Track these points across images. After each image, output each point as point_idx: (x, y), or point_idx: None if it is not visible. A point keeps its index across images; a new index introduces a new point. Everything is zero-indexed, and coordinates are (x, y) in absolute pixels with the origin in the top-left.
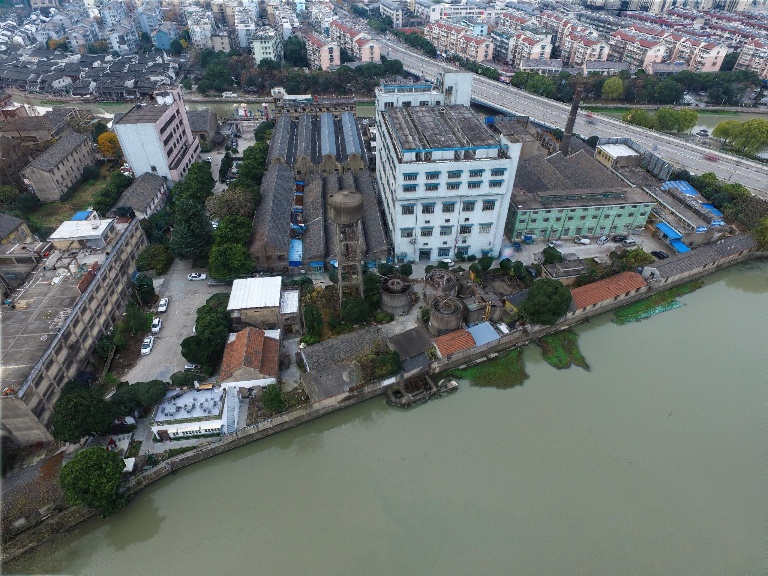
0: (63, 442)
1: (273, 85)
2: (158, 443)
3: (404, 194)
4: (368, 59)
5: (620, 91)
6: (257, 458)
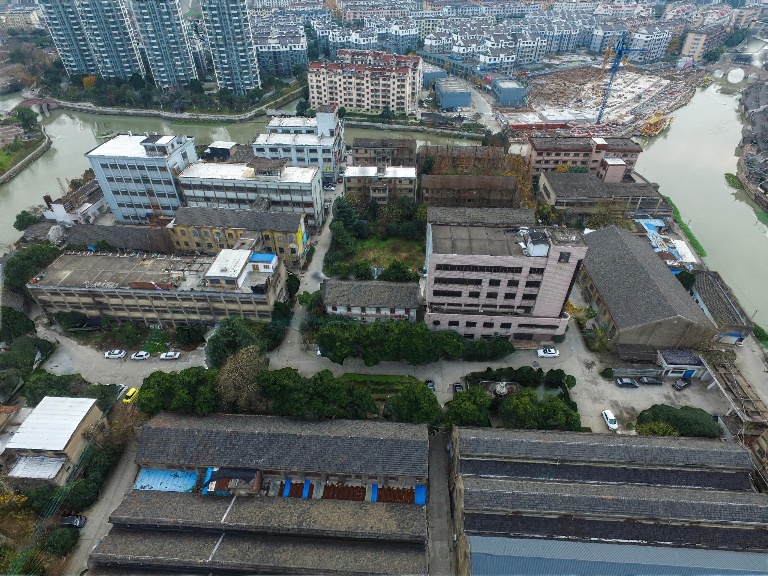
0: (49, 328)
1: None
2: None
3: None
4: None
5: None
6: None
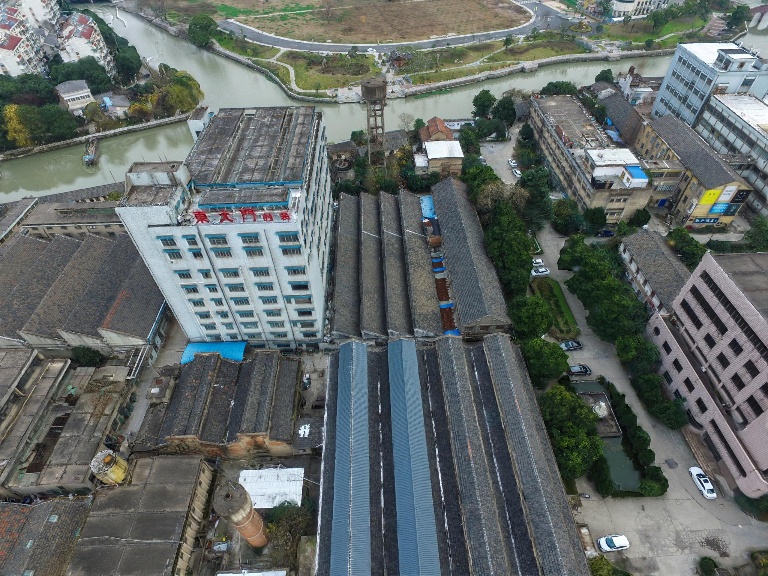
0: None
1: None
2: None
3: None
4: None
5: None
6: None
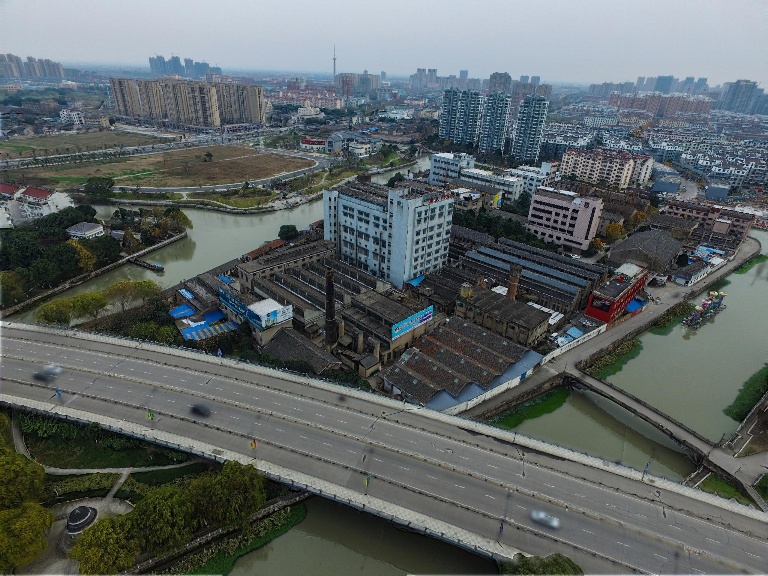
0: None
1: None
2: None
3: None
4: None
5: None
6: None
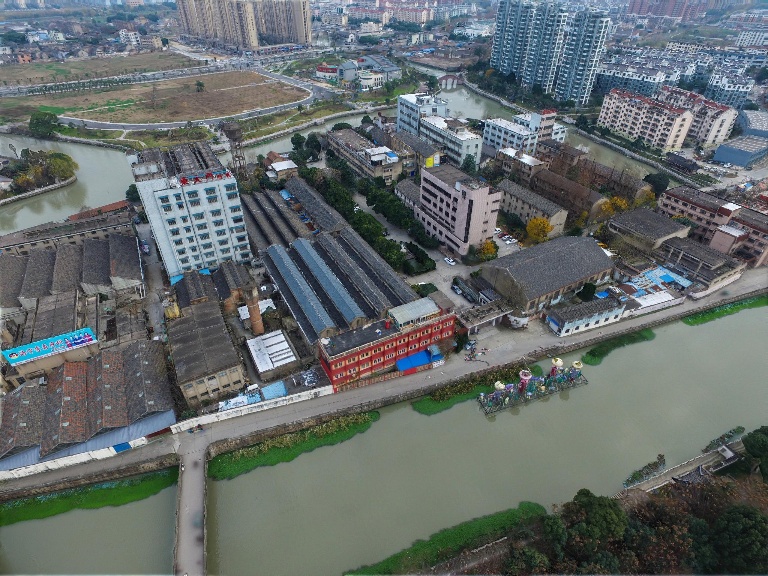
0: None
1: None
2: None
3: None
4: None
5: None
6: None
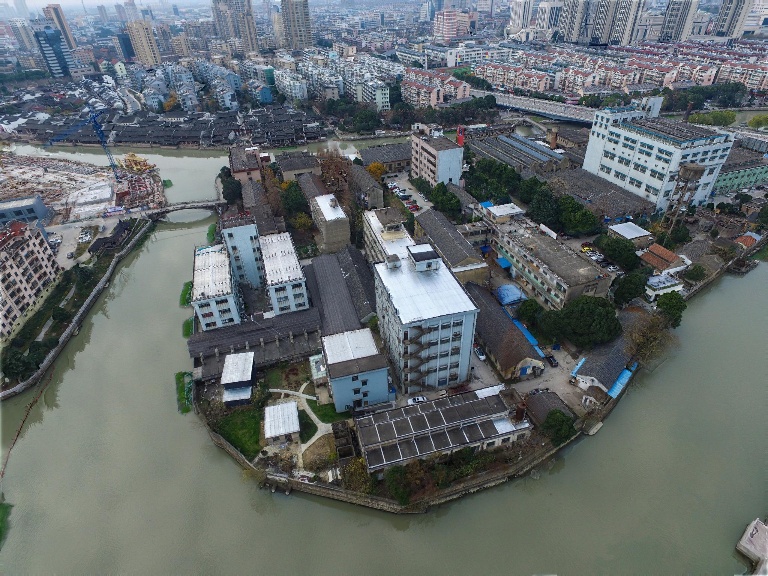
0: None
1: (413, 121)
2: (652, 303)
3: (678, 168)
4: (461, 96)
5: (665, 103)
6: (686, 310)
